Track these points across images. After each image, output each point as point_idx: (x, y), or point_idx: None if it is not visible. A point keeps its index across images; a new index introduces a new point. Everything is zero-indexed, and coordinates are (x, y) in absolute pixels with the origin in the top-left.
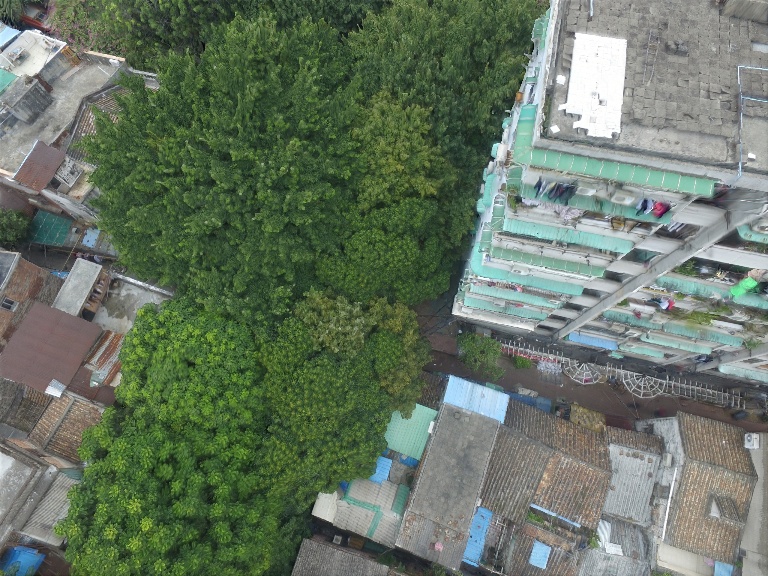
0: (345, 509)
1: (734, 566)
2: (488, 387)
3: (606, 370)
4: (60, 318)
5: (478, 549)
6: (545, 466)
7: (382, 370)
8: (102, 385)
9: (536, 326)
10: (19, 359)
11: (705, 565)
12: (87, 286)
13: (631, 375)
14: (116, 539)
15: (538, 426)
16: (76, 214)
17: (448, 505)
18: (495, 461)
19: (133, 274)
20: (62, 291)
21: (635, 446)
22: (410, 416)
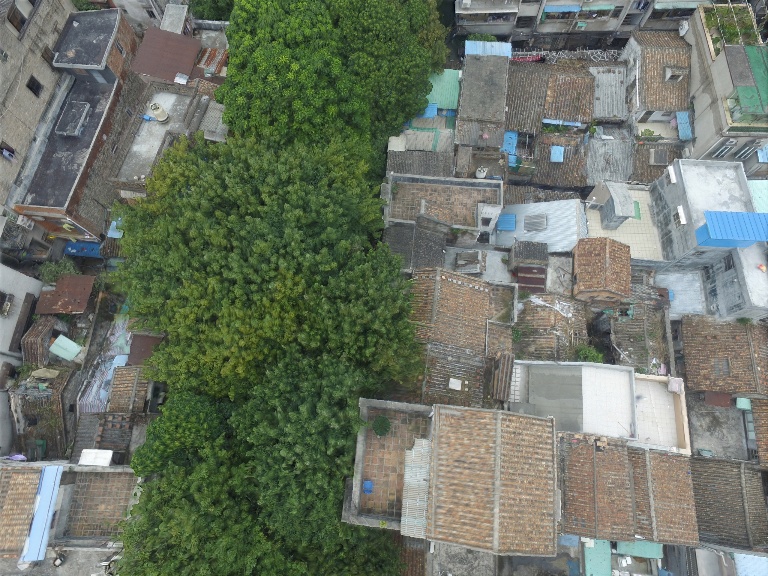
0: (412, 136)
1: (689, 110)
2: (495, 42)
3: (577, 53)
4: (170, 35)
5: (512, 156)
6: (547, 86)
7: (418, 25)
8: (214, 75)
9: (519, 8)
10: (149, 61)
11: (671, 131)
12: (180, 20)
13: (596, 52)
14: (277, 80)
15: (536, 66)
16: (136, 24)
17: (485, 107)
18: (511, 94)
19: (209, 19)
20: (162, 26)
21: (607, 66)
22: (443, 70)
